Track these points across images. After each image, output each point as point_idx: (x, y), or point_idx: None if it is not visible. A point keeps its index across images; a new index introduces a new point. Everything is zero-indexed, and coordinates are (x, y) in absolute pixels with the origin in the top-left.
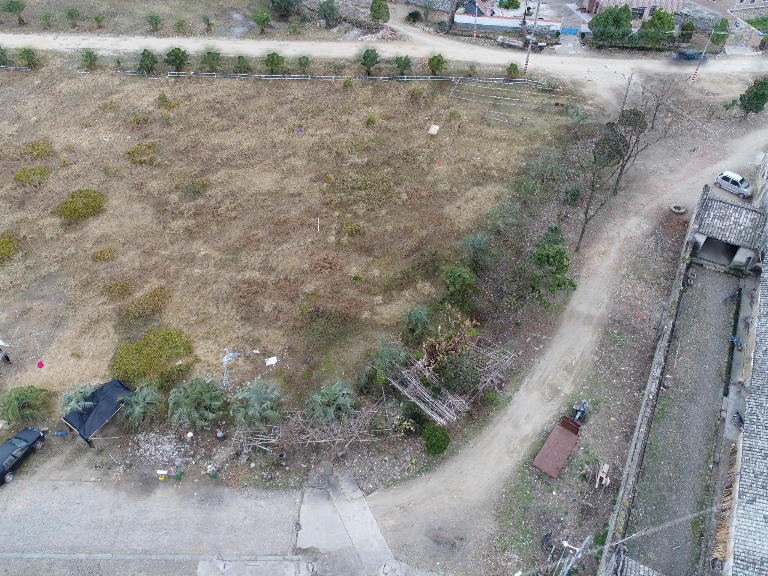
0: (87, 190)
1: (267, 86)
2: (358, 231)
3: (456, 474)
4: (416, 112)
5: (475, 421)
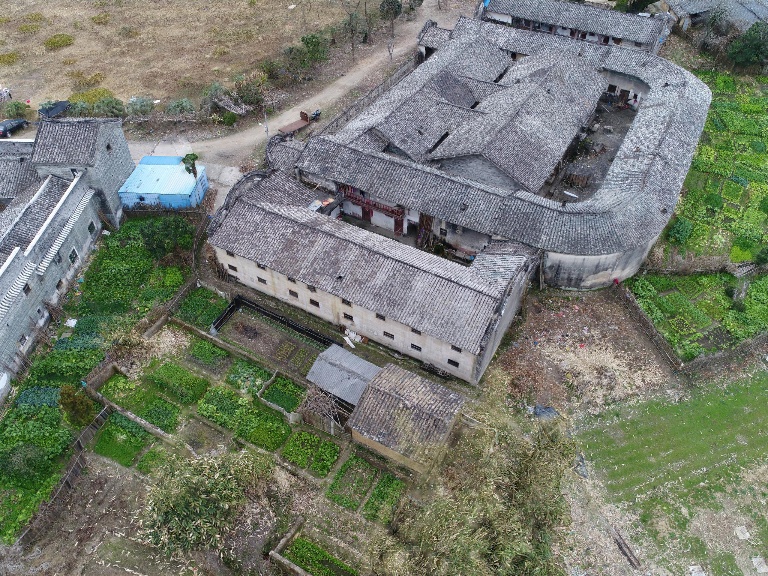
0: (63, 34)
1: None
2: (225, 52)
3: (240, 137)
4: (287, 0)
5: (259, 121)
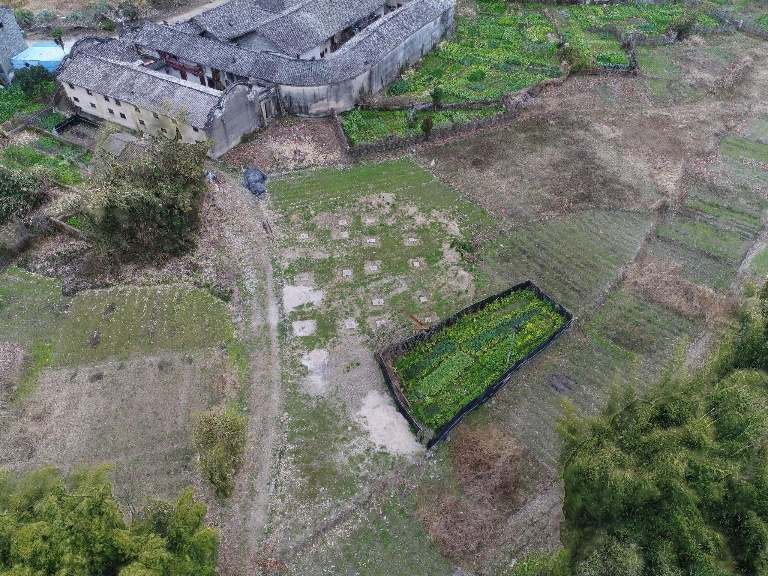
0: None
1: None
2: None
3: (117, 38)
4: None
5: None
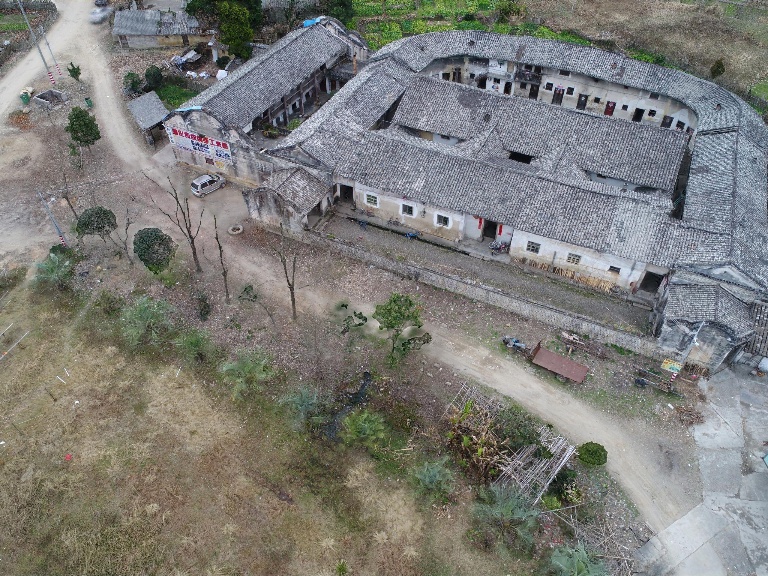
0: None
1: None
2: None
3: None
4: None
5: None
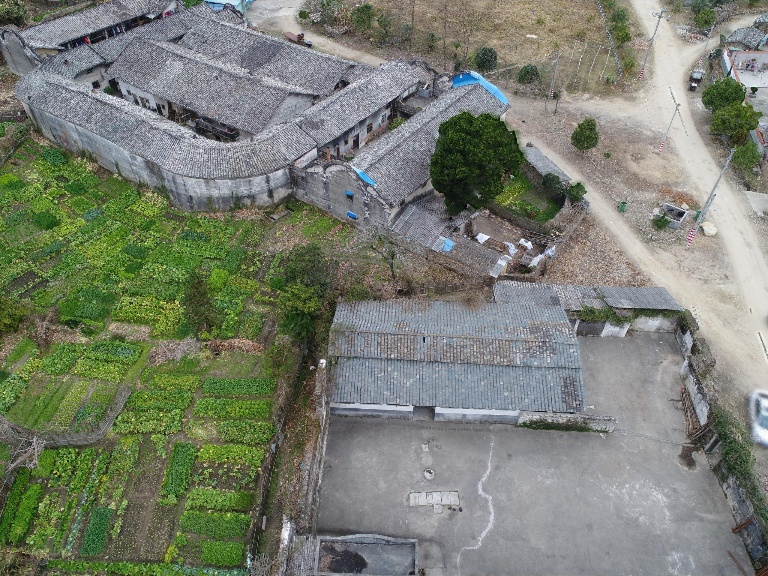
0: None
1: (588, 5)
2: None
3: None
4: None
5: (315, 31)
